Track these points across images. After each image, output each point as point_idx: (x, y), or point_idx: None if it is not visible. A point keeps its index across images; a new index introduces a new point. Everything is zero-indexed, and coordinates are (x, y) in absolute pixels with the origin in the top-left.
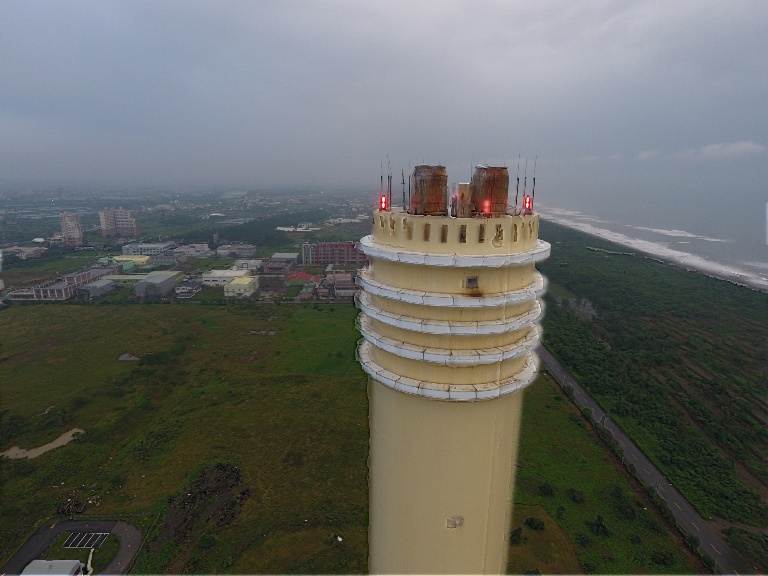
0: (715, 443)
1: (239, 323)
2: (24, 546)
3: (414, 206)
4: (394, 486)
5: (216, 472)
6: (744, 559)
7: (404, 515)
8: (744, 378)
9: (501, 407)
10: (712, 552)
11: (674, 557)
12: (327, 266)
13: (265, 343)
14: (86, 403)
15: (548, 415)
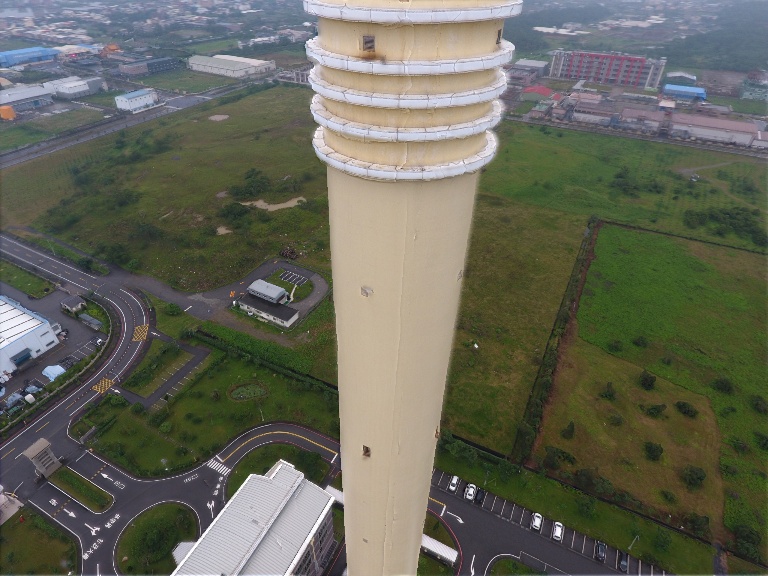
0: None
1: None
2: (257, 269)
3: None
4: (333, 250)
5: None
6: None
7: (339, 276)
8: None
9: (415, 198)
10: None
11: None
12: (577, 82)
13: None
14: (312, 179)
15: None
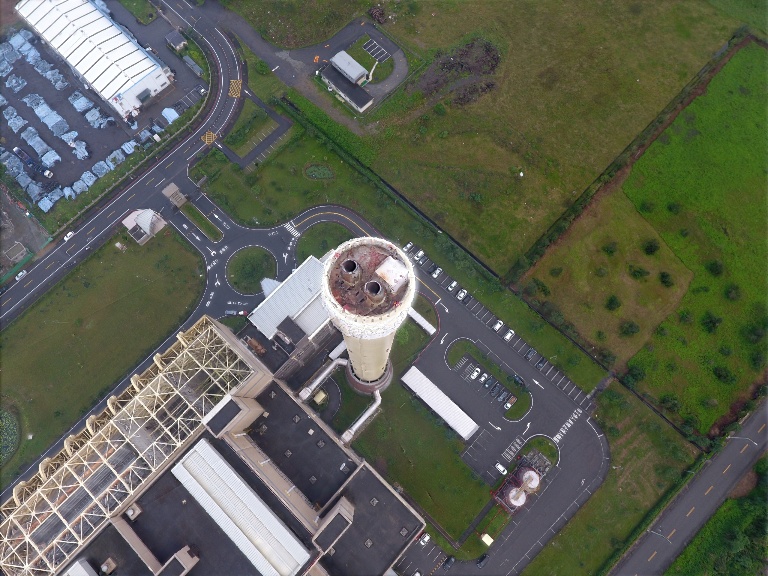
0: None
1: None
2: (343, 30)
3: None
4: None
5: (481, 51)
6: None
7: None
8: None
9: None
10: None
11: (733, 382)
12: None
13: None
14: None
15: None
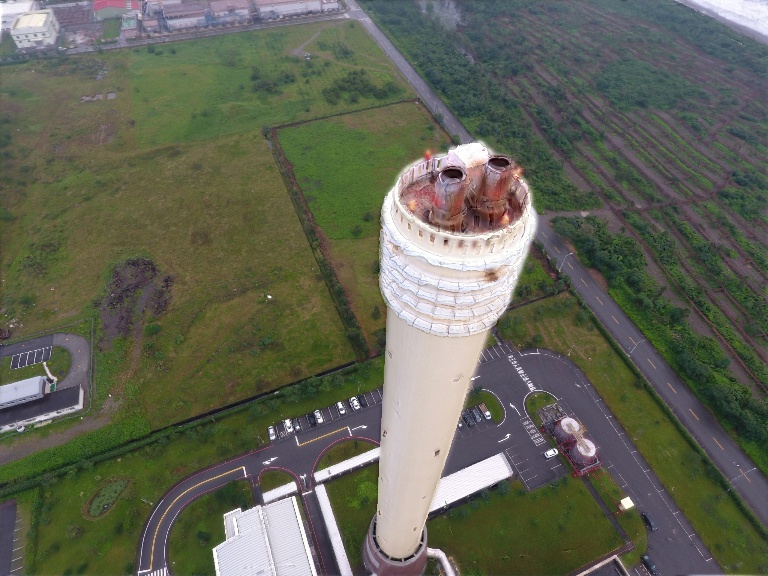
0: (552, 147)
1: (61, 88)
2: None
3: (443, 212)
4: (419, 369)
5: (129, 269)
6: (562, 237)
7: (425, 380)
8: (580, 78)
9: None
10: (542, 238)
11: None
12: None
13: (110, 112)
14: None
15: (423, 147)
